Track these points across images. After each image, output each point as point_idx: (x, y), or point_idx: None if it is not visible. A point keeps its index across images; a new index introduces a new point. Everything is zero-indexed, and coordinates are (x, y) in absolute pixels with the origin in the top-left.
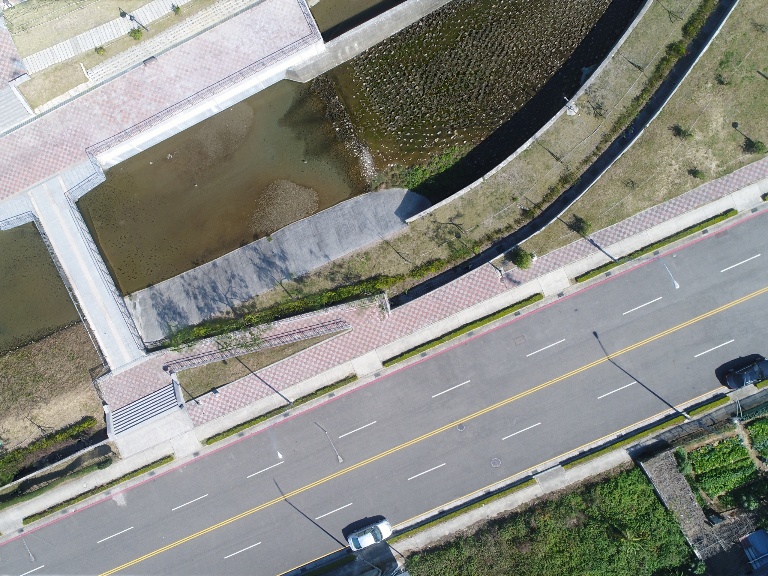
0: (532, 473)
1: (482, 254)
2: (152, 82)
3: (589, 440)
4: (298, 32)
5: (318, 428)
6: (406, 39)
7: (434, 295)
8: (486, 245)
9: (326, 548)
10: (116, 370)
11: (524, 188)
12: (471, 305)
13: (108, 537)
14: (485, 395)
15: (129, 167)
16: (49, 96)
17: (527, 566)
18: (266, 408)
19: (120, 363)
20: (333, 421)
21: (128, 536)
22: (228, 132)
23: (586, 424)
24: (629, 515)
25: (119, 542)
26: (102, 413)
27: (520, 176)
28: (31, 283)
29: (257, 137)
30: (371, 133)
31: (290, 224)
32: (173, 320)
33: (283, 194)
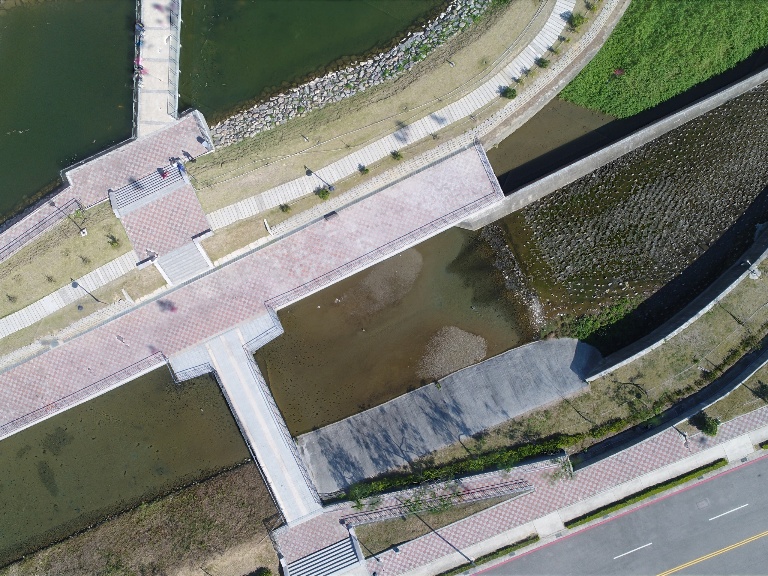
0: None
1: (662, 415)
2: (333, 237)
3: None
4: (480, 190)
5: None
6: (578, 190)
7: (617, 458)
8: (666, 406)
9: None
10: (292, 523)
11: (705, 350)
12: (654, 469)
13: None
14: (667, 558)
15: (296, 310)
16: (229, 249)
17: None
18: (446, 566)
19: (296, 516)
20: None
21: None
22: (397, 278)
23: None
24: None
25: None
26: (277, 564)
27: (701, 338)
28: (195, 424)
29: (426, 283)
30: (541, 282)
31: (458, 371)
32: (347, 471)
33: (451, 341)
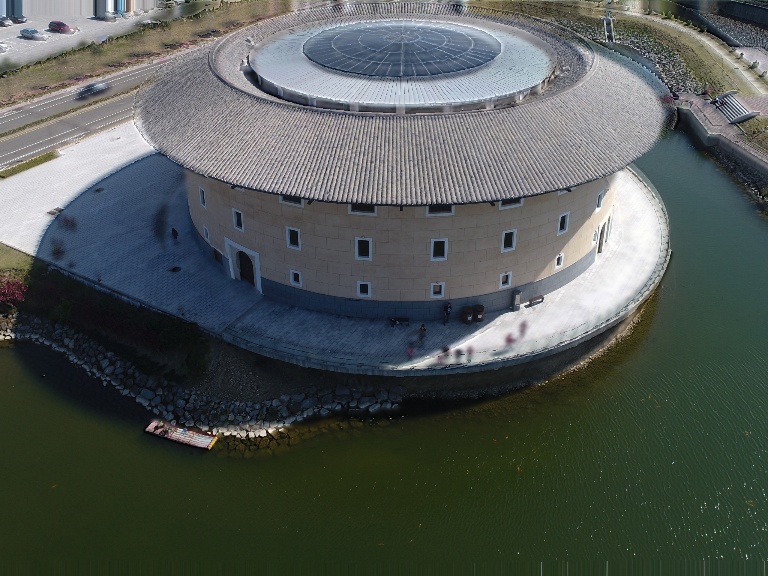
0: None
1: None
2: None
3: None
4: None
5: None
6: None
7: None
8: None
9: None
10: None
11: None
12: None
13: None
14: None
15: None
16: None
17: None
18: None
19: None
20: None
21: None
22: None
23: None
24: None
25: None
26: None
27: None
28: None
29: None
30: None
31: None
32: None
33: None
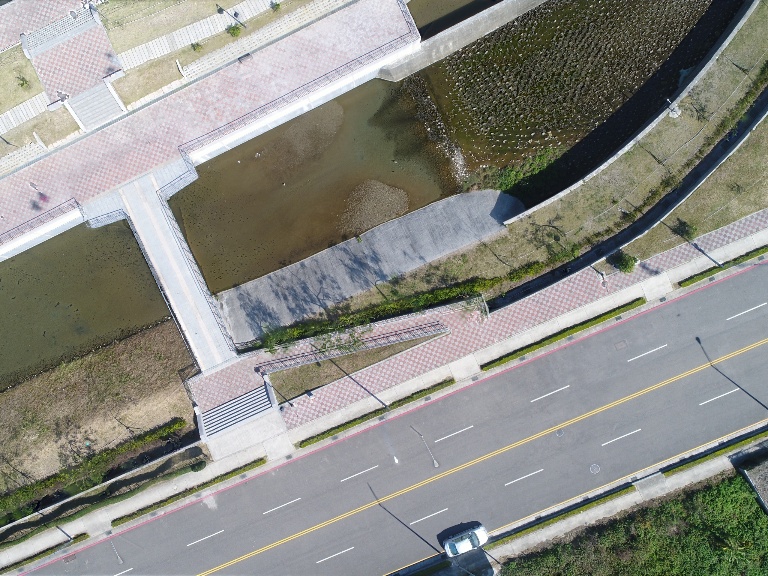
0: (631, 480)
1: (581, 257)
2: (247, 80)
3: (690, 447)
4: (396, 30)
5: (414, 432)
6: (500, 39)
7: (534, 298)
8: (585, 248)
9: (420, 554)
10: (207, 371)
11: (625, 191)
12: (572, 309)
13: (198, 540)
14: (585, 400)
15: (216, 165)
16: (142, 93)
17: (627, 574)
18: (361, 411)
19: (211, 364)
20: (429, 425)
21: (218, 539)
22: (317, 131)
23: (687, 431)
24: (731, 523)
25: (209, 545)
26: (192, 414)
27: (621, 179)
28: (115, 282)
29: (347, 136)
30: (463, 133)
31: (380, 225)
32: (264, 321)
33: (373, 194)
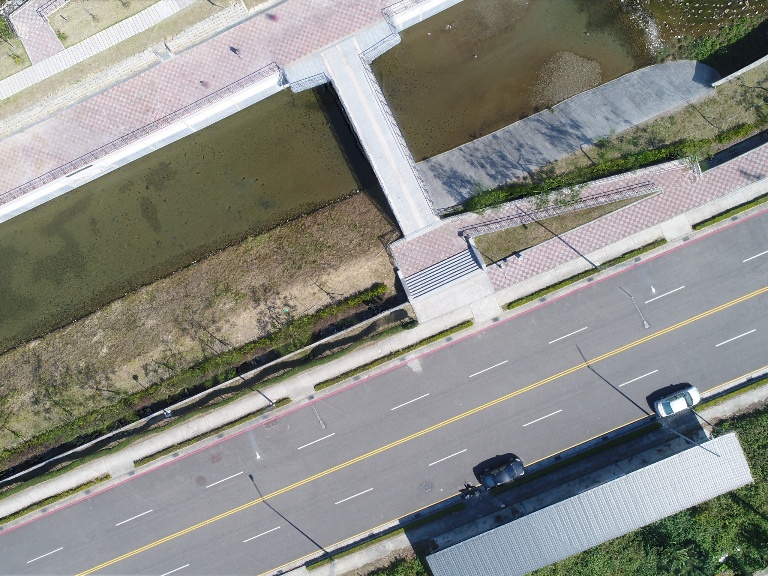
0: None
1: None
2: None
3: None
4: None
5: (623, 293)
6: None
7: (747, 157)
8: None
9: (629, 416)
10: (409, 235)
11: None
12: None
13: (402, 404)
14: None
15: (406, 38)
16: None
17: None
18: (570, 272)
19: (413, 228)
20: (639, 286)
21: (423, 403)
22: (509, 3)
23: None
24: None
25: (414, 409)
26: (393, 280)
27: None
28: (302, 156)
29: (539, 8)
30: (658, 4)
31: (572, 96)
32: (463, 187)
33: (565, 66)
